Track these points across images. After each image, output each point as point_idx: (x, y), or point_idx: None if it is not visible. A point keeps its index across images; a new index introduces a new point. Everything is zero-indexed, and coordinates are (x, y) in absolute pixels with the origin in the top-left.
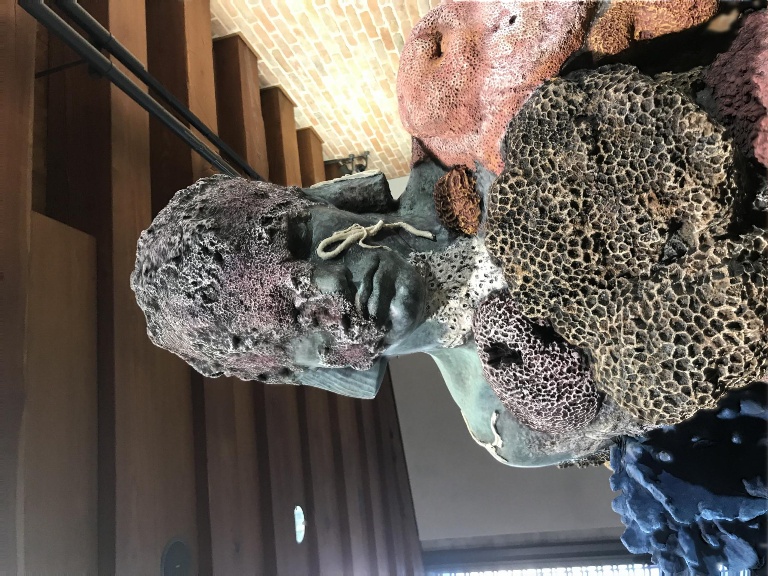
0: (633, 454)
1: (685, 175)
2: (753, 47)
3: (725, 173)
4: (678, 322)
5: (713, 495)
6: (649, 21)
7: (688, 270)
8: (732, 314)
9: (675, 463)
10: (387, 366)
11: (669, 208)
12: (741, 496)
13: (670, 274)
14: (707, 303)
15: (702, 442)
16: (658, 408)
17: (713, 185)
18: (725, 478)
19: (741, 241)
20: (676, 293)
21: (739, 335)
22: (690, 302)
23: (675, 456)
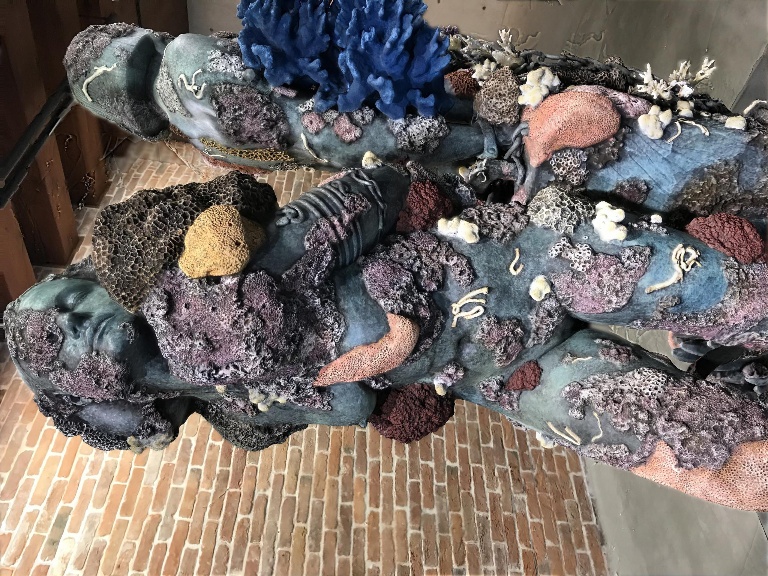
0: None
1: None
2: None
3: None
4: None
5: None
6: None
7: None
8: None
9: None
10: (149, 56)
11: None
12: None
13: None
14: None
15: None
16: None
17: None
18: None
19: None
20: None
21: None
22: None
23: None
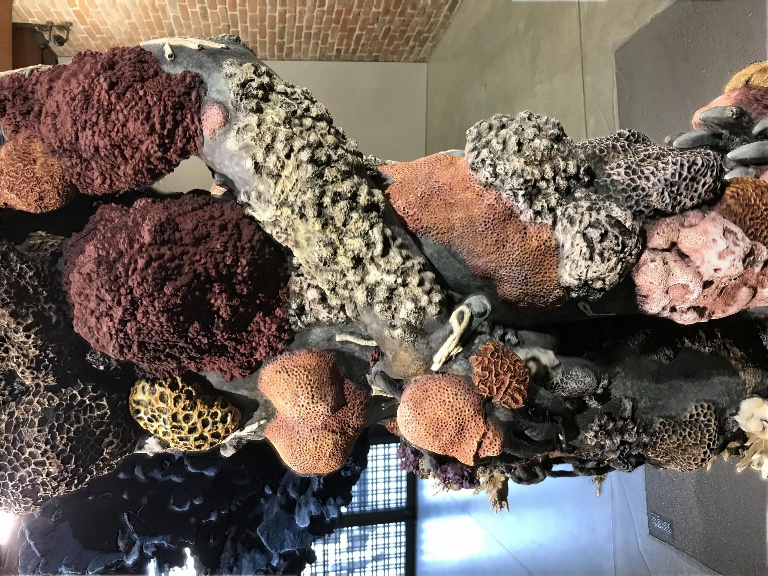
0: (37, 510)
1: (7, 346)
2: (89, 240)
3: (36, 350)
4: (5, 453)
5: (82, 549)
6: (7, 198)
7: (19, 412)
8: (39, 454)
9: (67, 519)
10: None
11: (4, 363)
12: (100, 550)
13: (9, 411)
14: (23, 443)
15: (107, 494)
16: (1, 508)
17: (30, 356)
18: (104, 530)
19: (61, 394)
20: (5, 431)
21: (43, 470)
22: (13, 440)
23: (69, 513)
